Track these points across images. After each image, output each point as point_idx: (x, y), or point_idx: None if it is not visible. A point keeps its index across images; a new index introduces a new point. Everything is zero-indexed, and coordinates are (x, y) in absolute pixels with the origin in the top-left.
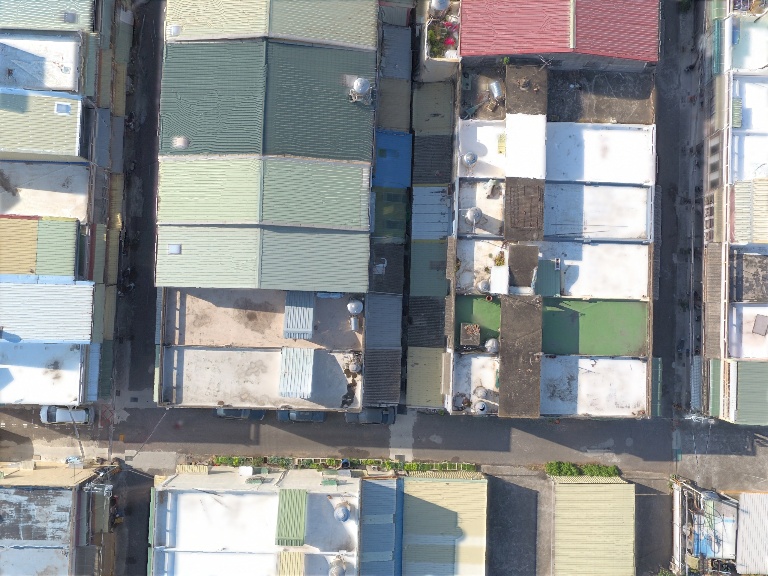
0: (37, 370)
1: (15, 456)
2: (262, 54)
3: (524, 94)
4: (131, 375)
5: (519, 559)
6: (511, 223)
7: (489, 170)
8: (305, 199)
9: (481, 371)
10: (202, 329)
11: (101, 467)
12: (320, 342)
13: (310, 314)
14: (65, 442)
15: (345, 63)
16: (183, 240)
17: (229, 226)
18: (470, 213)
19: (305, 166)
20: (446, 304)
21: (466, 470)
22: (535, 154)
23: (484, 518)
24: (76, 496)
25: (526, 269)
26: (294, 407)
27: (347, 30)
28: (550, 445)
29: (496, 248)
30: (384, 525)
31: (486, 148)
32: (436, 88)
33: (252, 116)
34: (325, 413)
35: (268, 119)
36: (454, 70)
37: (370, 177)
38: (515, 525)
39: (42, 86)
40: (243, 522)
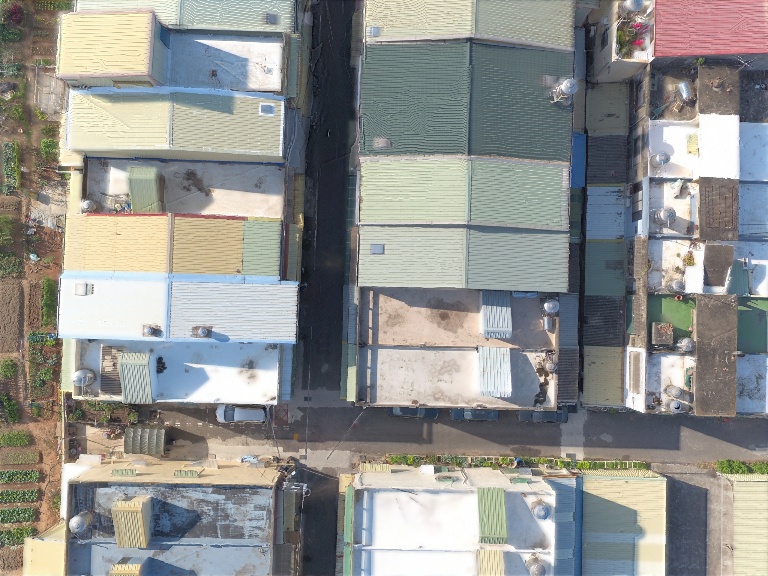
0: (232, 369)
1: (190, 455)
2: (466, 55)
3: (717, 94)
4: (304, 374)
5: (690, 556)
6: (706, 223)
7: (676, 170)
8: (510, 199)
9: (670, 370)
10: (395, 328)
11: (279, 466)
12: (512, 341)
13: (508, 313)
14: (239, 441)
15: (544, 64)
16: (386, 240)
17: (434, 226)
18: (664, 213)
19: (512, 166)
20: (634, 303)
21: (637, 468)
22: (729, 154)
23: (663, 516)
24: (274, 495)
25: (721, 269)
26: (488, 406)
27: (547, 31)
28: (719, 443)
29: (684, 248)
30: (565, 523)
31: (673, 148)
32: (610, 88)
33: (459, 117)
34: (499, 412)
35: (473, 120)
36: (638, 71)
37: (569, 177)
38: (685, 523)
39: (245, 87)
40: (438, 520)
